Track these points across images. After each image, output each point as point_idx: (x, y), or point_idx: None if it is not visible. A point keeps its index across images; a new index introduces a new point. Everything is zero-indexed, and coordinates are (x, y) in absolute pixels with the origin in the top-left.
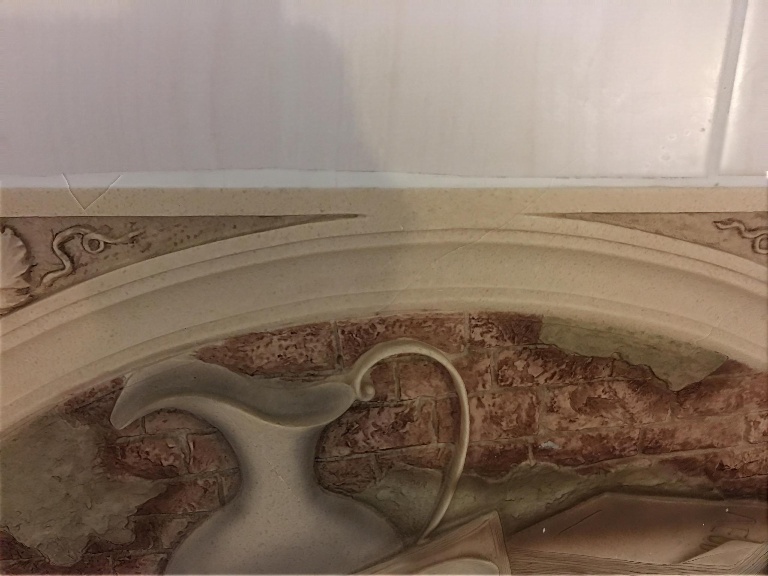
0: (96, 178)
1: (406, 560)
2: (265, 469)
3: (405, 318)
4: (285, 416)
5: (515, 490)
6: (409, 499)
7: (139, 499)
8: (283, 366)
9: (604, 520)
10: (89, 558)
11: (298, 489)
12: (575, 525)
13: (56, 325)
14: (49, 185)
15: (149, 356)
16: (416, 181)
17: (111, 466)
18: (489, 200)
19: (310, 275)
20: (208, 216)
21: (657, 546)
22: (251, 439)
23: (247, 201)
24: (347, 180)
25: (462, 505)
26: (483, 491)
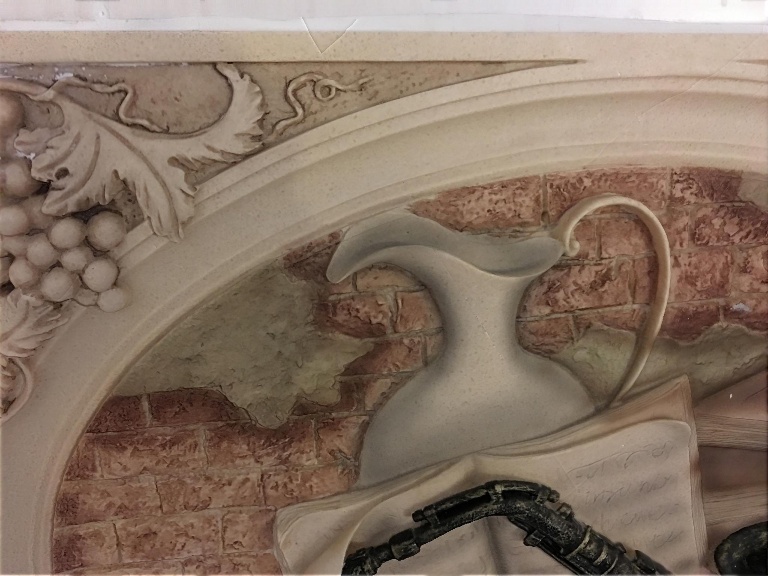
0: (334, 22)
1: (602, 421)
2: (473, 325)
3: (611, 172)
4: (493, 271)
5: (706, 353)
6: (603, 361)
7: (347, 357)
8: (491, 221)
9: None
10: (294, 420)
11: (502, 346)
12: (761, 391)
13: (285, 174)
14: (289, 29)
15: (366, 209)
16: (635, 26)
17: (322, 324)
18: (704, 46)
19: (523, 127)
20: (435, 62)
21: None
22: (463, 292)
23: (475, 45)
24: (569, 25)
25: (654, 368)
26: (675, 354)
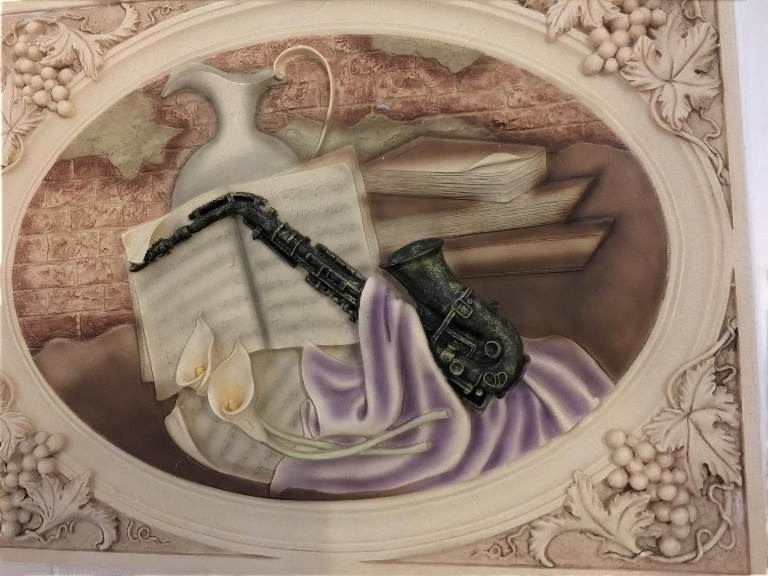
0: None
1: (299, 166)
2: (228, 114)
3: (302, 39)
4: None
5: (364, 132)
6: (304, 138)
7: (169, 137)
8: (242, 66)
9: (419, 151)
10: (141, 175)
11: (244, 126)
12: (402, 155)
13: (144, 46)
14: None
15: (182, 63)
16: None
17: (158, 121)
18: None
19: (257, 22)
20: None
21: (452, 163)
22: (222, 95)
23: None
24: None
25: (334, 142)
26: (346, 133)
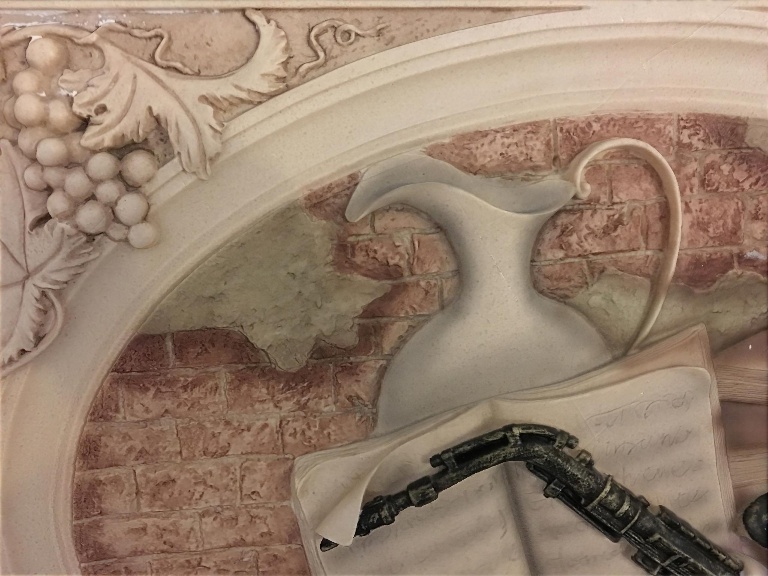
0: None
1: (619, 367)
2: (488, 265)
3: (619, 117)
4: None
5: (722, 301)
6: (619, 308)
7: (365, 299)
8: (504, 165)
9: None
10: (312, 364)
11: (517, 288)
12: None
13: (307, 114)
14: None
15: (384, 151)
16: None
17: (341, 265)
18: None
19: (532, 74)
20: (448, 9)
21: None
22: (478, 230)
23: None
24: None
25: (670, 316)
26: (690, 301)
